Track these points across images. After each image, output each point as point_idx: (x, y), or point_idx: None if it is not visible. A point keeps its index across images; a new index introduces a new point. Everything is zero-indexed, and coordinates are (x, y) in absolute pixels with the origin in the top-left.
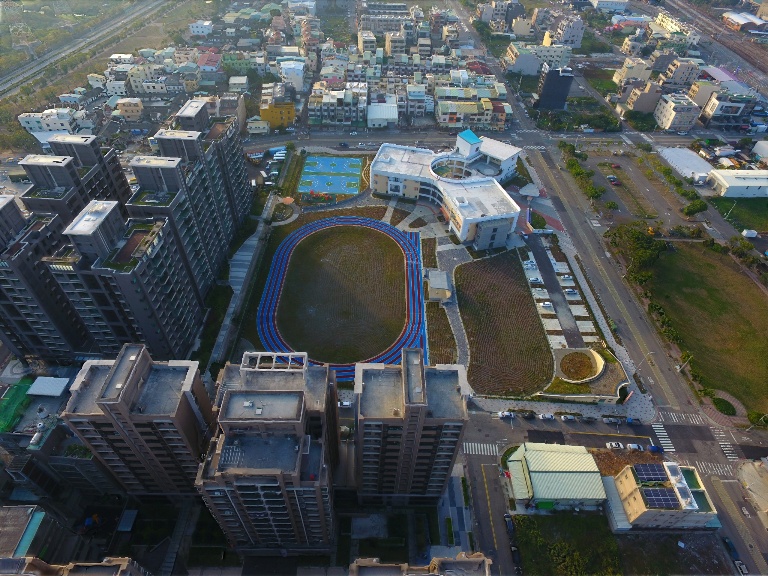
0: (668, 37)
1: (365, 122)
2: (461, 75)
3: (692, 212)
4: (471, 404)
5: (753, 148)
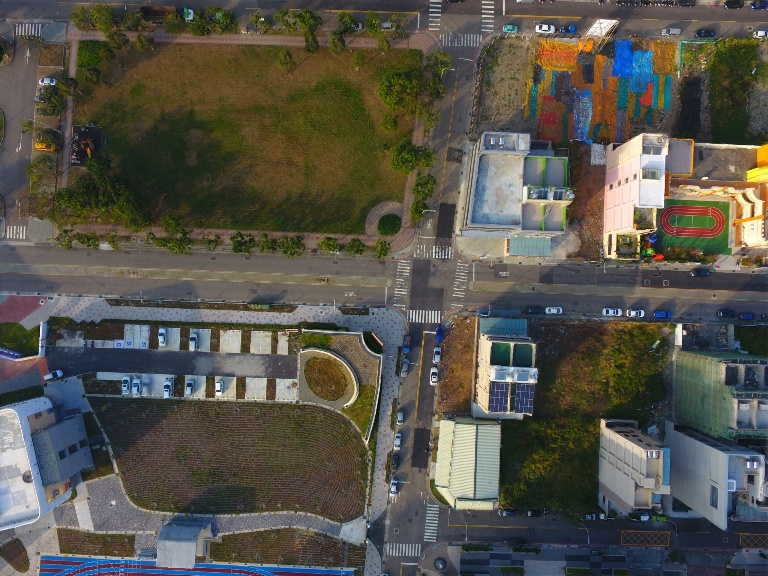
0: None
1: None
2: None
3: None
4: (377, 524)
5: None
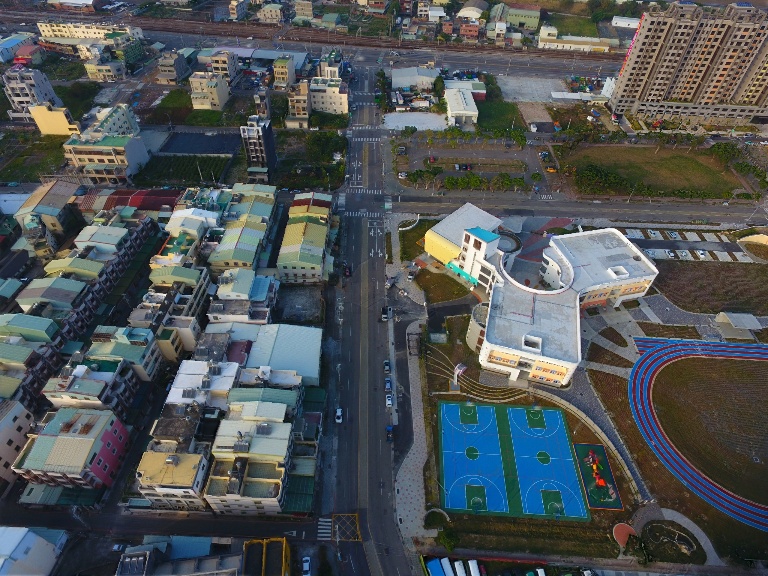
0: (111, 43)
1: (307, 389)
2: (204, 217)
3: None
4: None
5: (392, 85)
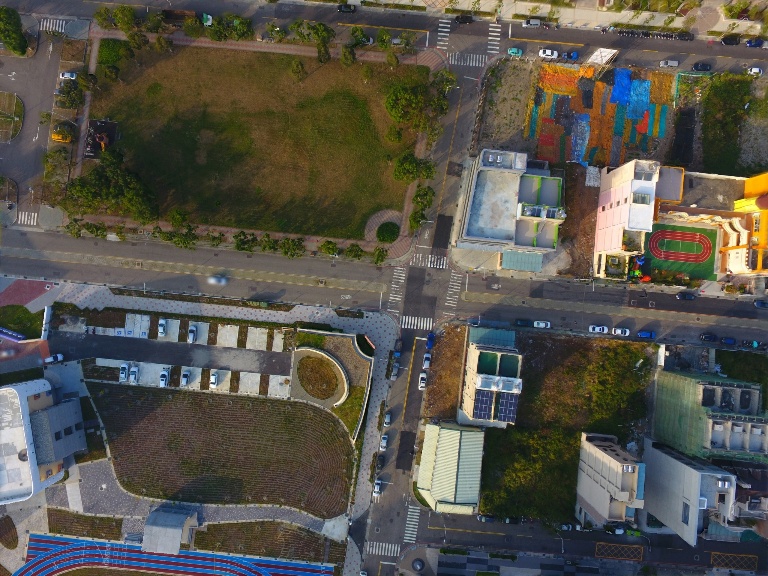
0: None
1: None
2: None
3: (22, 44)
4: (359, 522)
5: None
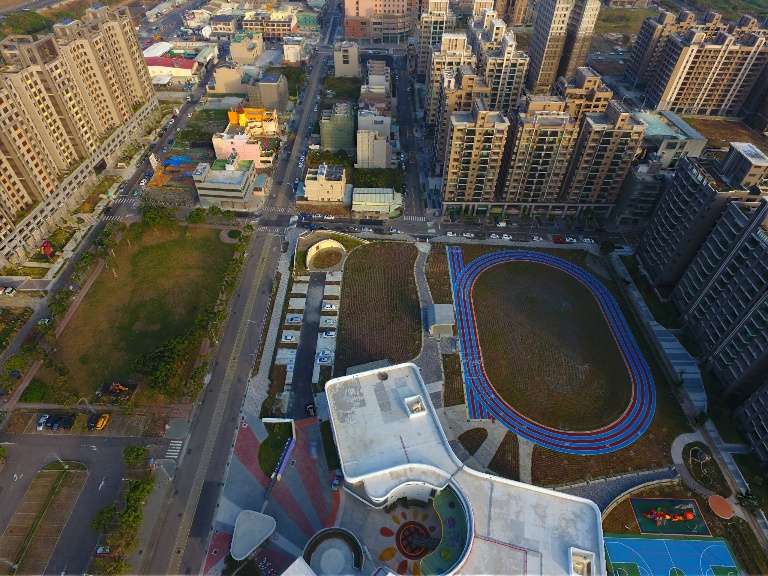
0: None
1: None
2: None
3: None
4: None
5: None
